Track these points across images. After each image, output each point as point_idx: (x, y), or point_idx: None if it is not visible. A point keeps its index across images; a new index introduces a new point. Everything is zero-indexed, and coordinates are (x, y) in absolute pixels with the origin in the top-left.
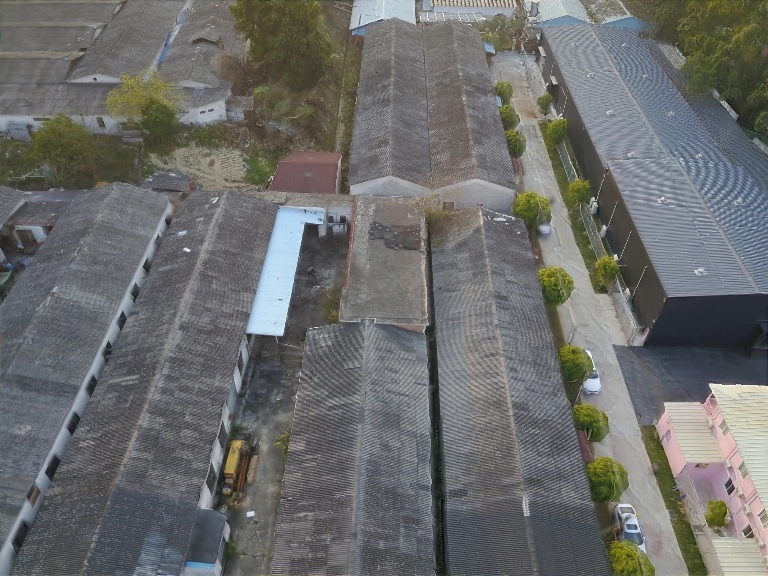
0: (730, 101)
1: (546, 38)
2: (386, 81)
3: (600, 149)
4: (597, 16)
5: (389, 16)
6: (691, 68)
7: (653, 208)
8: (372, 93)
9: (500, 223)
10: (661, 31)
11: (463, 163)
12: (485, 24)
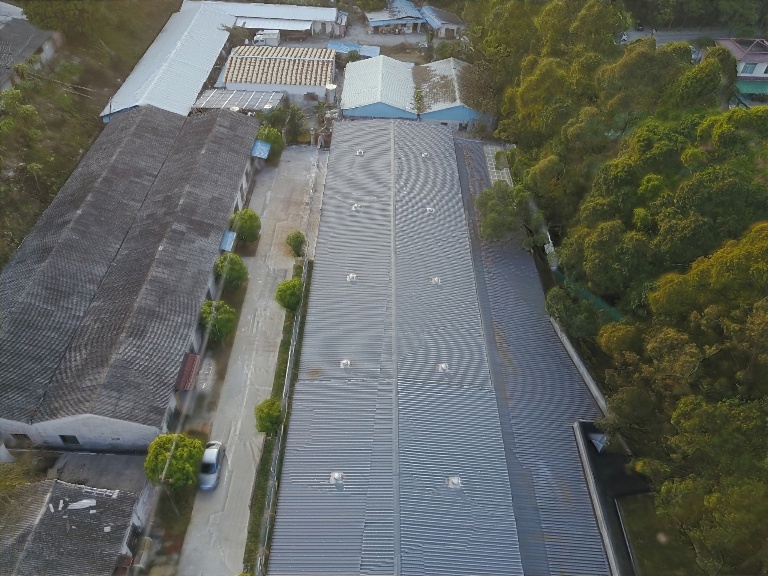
0: (556, 234)
1: (331, 140)
2: (71, 214)
3: (307, 349)
4: (424, 101)
5: (152, 99)
6: (486, 202)
7: (316, 495)
8: (44, 233)
9: (78, 513)
10: (492, 127)
11: (90, 377)
12: (267, 115)
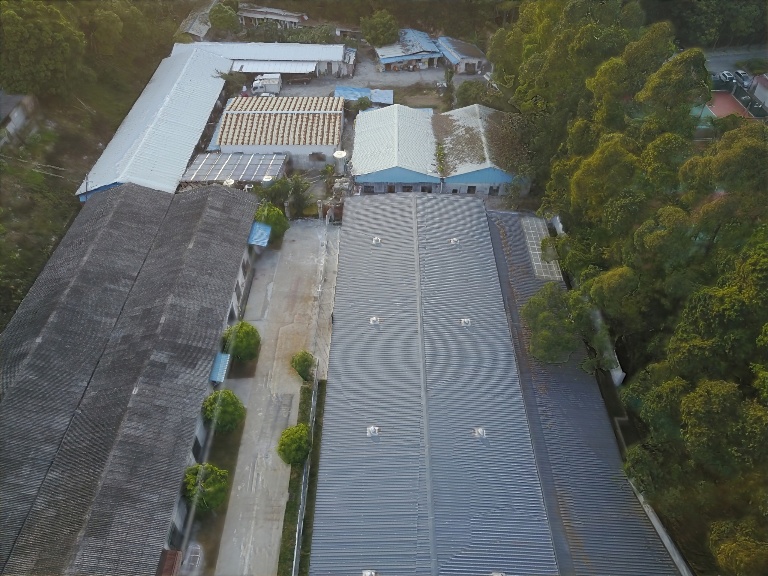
0: None
1: None
2: (29, 342)
3: (318, 550)
4: (447, 160)
5: (134, 173)
6: (536, 314)
7: None
8: None
9: None
10: (530, 194)
11: None
12: (266, 189)
